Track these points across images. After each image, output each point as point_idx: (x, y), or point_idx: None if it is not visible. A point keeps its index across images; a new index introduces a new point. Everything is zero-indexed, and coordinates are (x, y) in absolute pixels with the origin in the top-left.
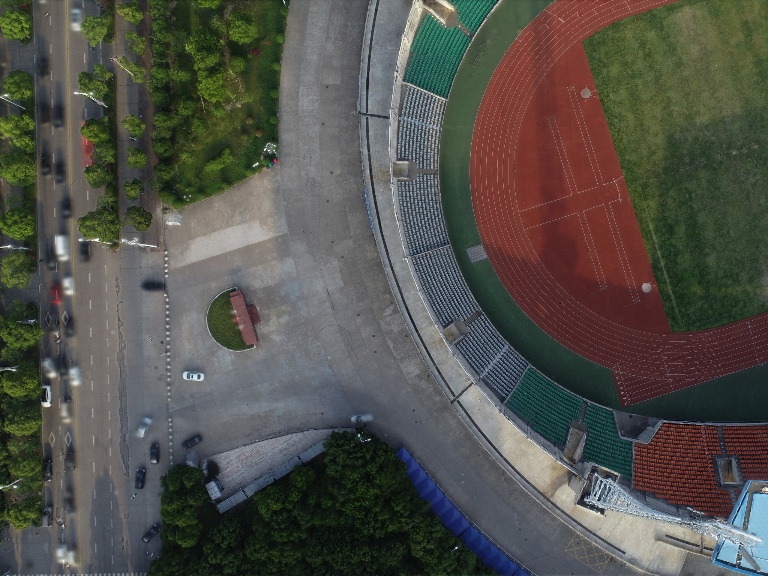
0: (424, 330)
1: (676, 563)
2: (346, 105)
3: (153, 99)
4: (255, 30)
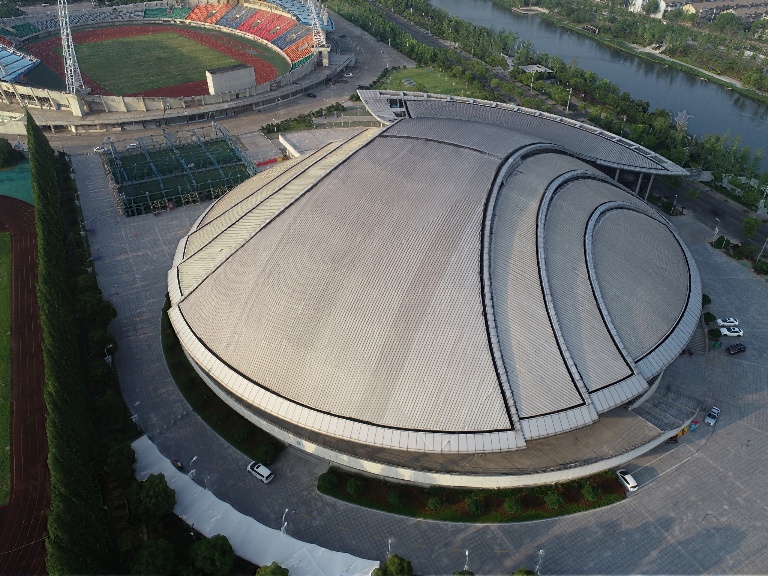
0: None
1: None
2: None
3: None
4: None
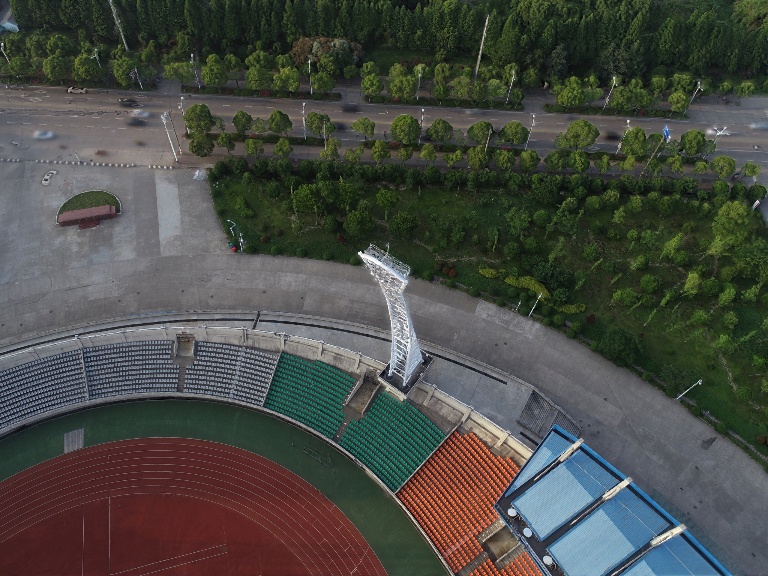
0: None
1: None
2: None
3: (303, 161)
4: (355, 231)
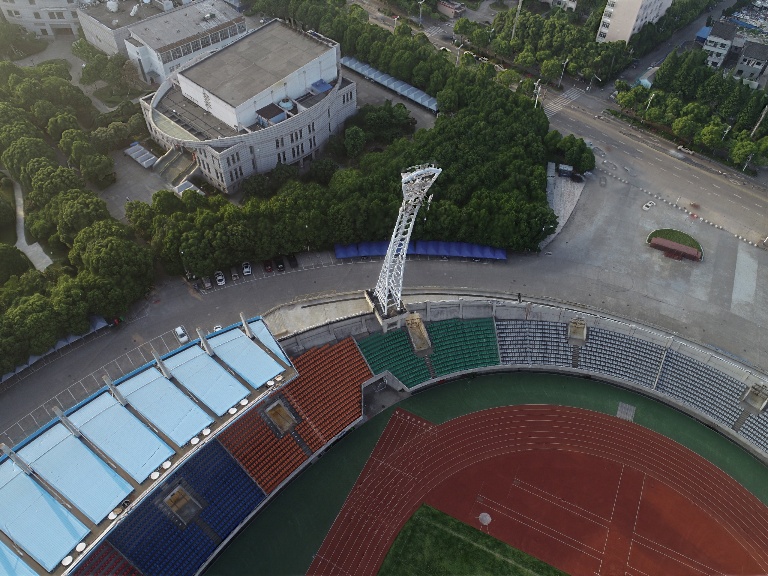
0: None
1: None
2: None
3: None
4: None
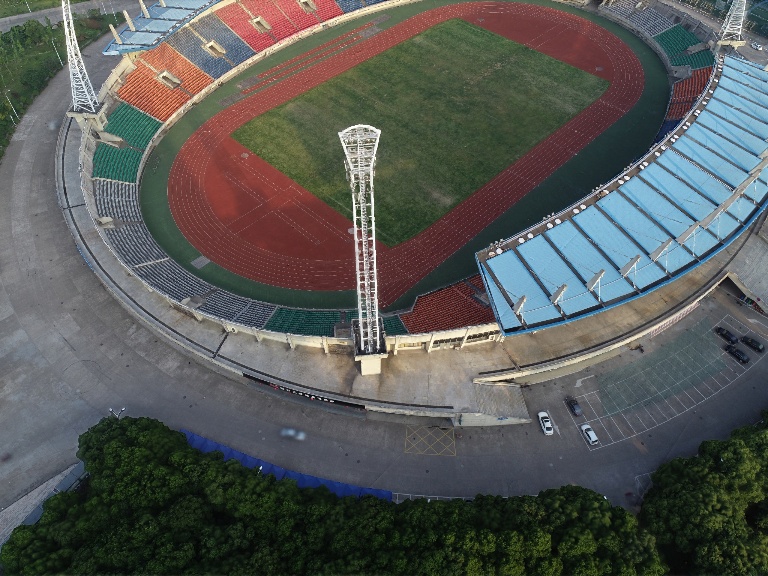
0: (164, 316)
1: (516, 405)
2: (55, 219)
3: None
4: None
